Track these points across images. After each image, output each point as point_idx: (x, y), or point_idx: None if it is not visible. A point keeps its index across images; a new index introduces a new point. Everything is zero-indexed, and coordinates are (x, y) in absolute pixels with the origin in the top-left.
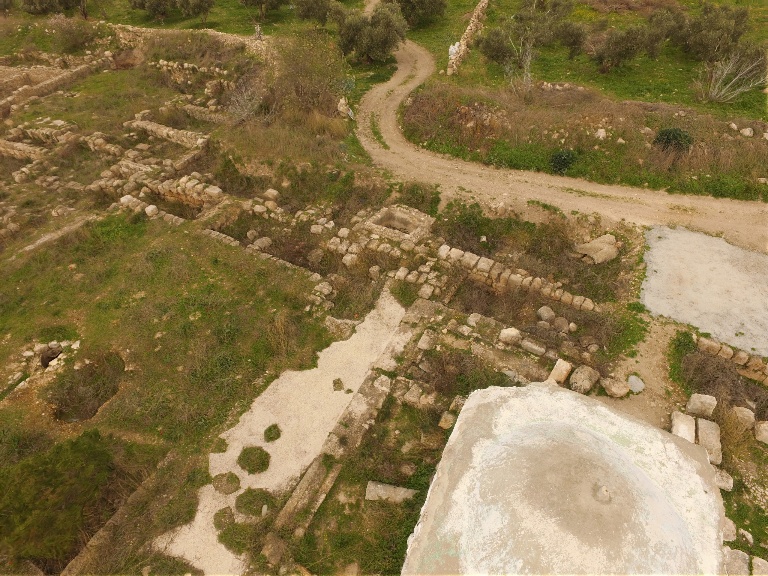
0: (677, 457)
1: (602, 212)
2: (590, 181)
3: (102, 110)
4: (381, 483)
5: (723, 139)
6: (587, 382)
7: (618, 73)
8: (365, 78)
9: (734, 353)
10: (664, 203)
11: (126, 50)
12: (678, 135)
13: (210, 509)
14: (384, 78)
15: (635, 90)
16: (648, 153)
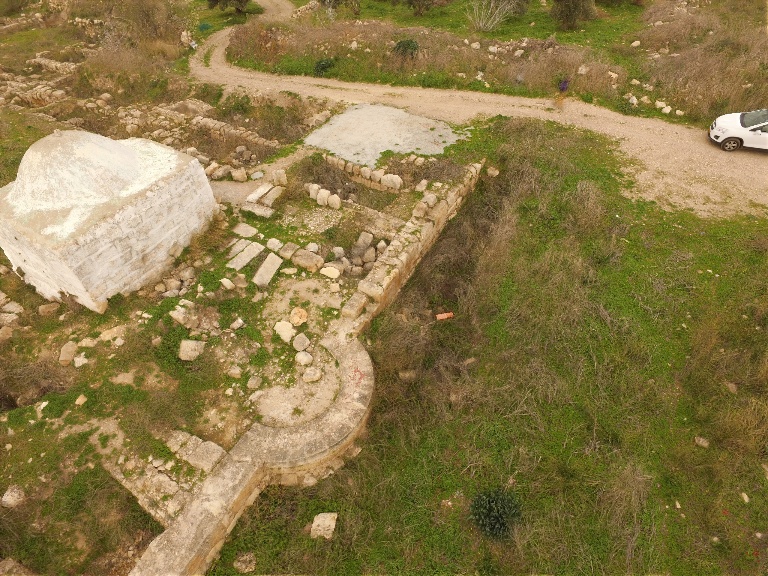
0: (172, 159)
1: (331, 97)
2: (339, 80)
3: (14, 53)
4: None
5: (450, 49)
6: (221, 172)
7: (429, 16)
8: (223, 22)
9: (346, 164)
10: (382, 92)
11: (55, 13)
12: (407, 44)
13: None
14: (239, 23)
15: (427, 25)
16: (386, 59)
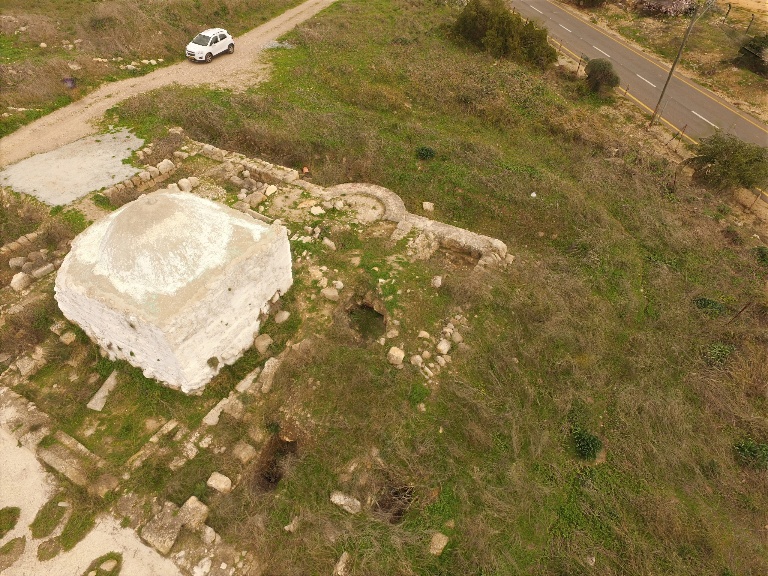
0: None
1: None
2: None
3: None
4: (93, 396)
5: None
6: None
7: None
8: None
9: (124, 185)
10: None
11: None
12: None
13: (30, 567)
14: None
15: None
16: None
